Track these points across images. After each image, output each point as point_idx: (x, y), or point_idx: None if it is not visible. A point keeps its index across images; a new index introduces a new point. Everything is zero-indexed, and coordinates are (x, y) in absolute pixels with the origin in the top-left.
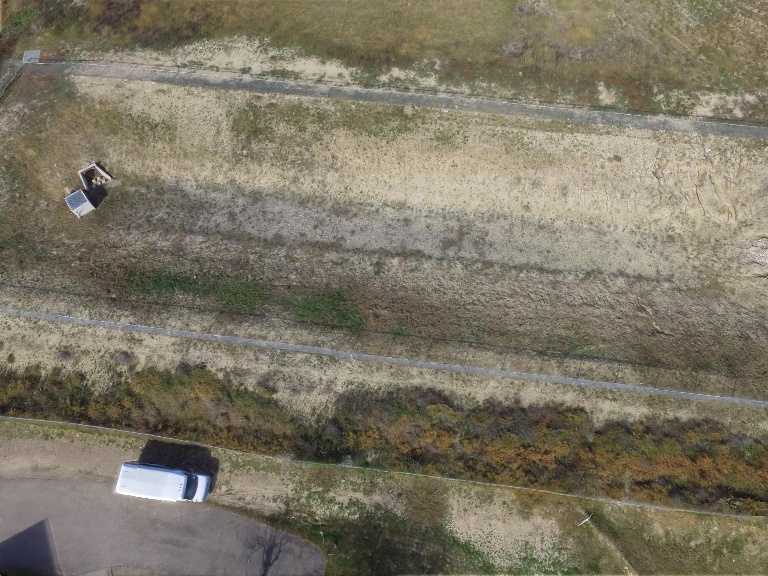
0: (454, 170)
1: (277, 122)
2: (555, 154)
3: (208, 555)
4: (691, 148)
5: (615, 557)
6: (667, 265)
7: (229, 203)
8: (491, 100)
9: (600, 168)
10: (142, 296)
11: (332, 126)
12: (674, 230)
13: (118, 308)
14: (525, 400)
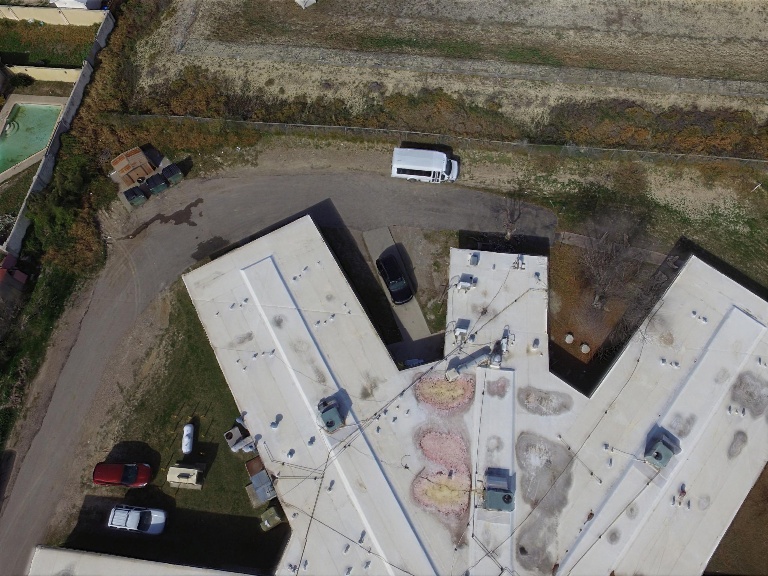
0: None
1: None
2: None
3: (464, 217)
4: None
5: None
6: None
7: None
8: None
9: None
10: (378, 49)
11: None
12: None
13: (363, 55)
14: (701, 106)
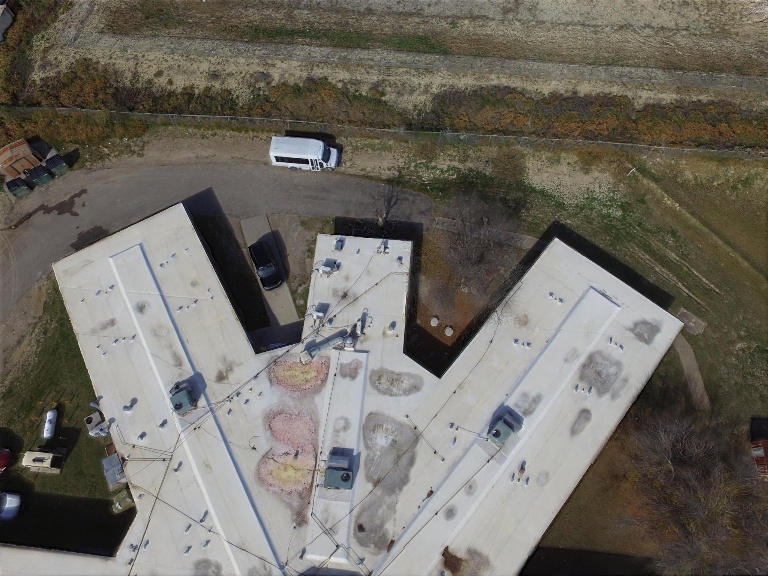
0: None
1: None
2: None
3: (341, 203)
4: None
5: (657, 193)
6: (684, 20)
7: None
8: None
9: None
10: (269, 39)
11: None
12: None
13: (252, 45)
14: (581, 92)
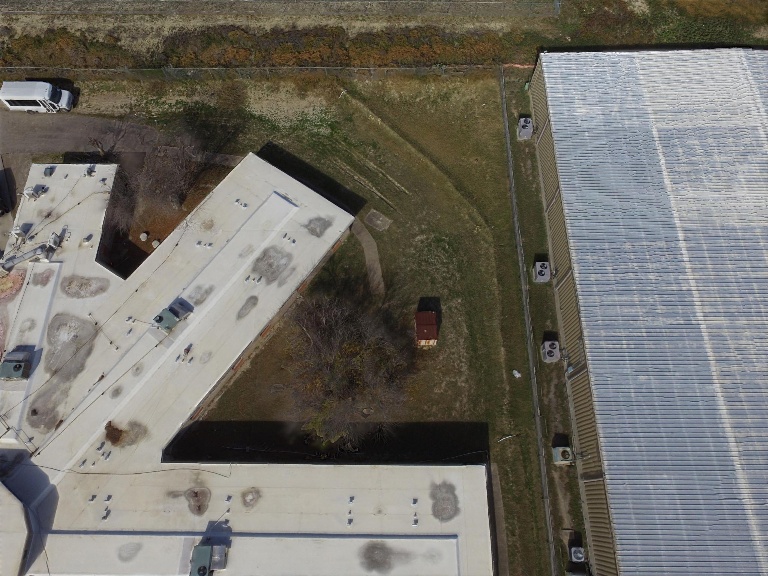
0: None
1: None
2: None
3: (72, 140)
4: None
5: (363, 111)
6: None
7: None
8: None
9: None
10: None
11: None
12: None
13: None
14: (300, 26)
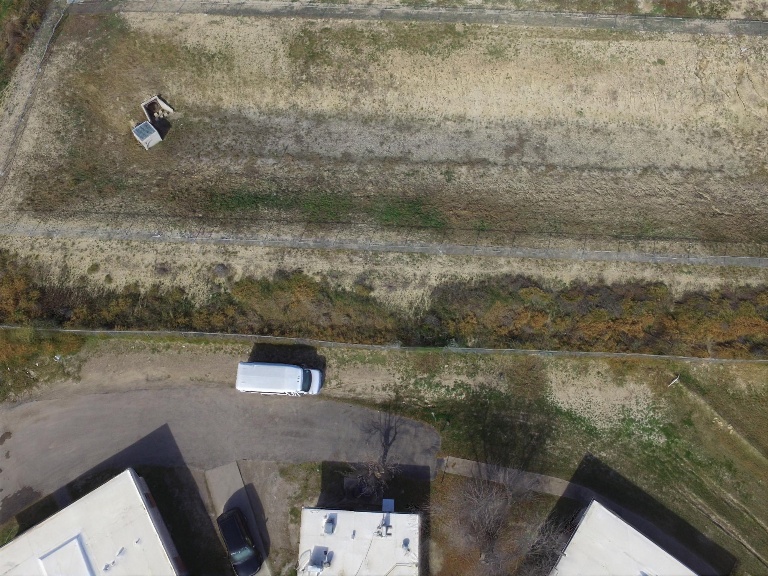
0: (509, 82)
1: (333, 46)
2: (603, 61)
3: (328, 442)
4: (728, 48)
5: (704, 410)
6: (716, 157)
7: (294, 127)
8: (537, 14)
9: (646, 72)
10: (228, 213)
11: (388, 47)
12: (719, 125)
13: (207, 225)
14: (608, 279)
